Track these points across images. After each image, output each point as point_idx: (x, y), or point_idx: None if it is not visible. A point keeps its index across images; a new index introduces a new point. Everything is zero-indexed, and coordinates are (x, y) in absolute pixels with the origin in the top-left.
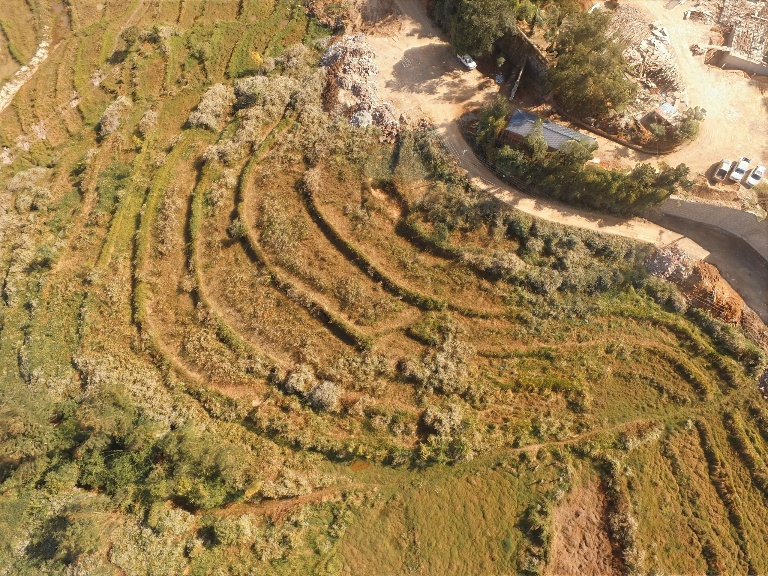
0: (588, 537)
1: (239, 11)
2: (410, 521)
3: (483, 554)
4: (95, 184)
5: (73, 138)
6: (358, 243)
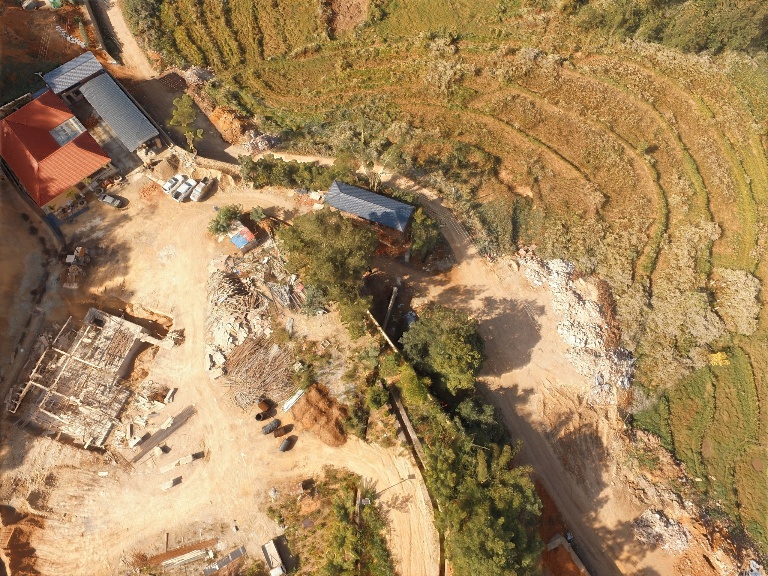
0: (346, 8)
1: None
2: (456, 13)
3: (409, 2)
4: None
5: None
6: (533, 148)
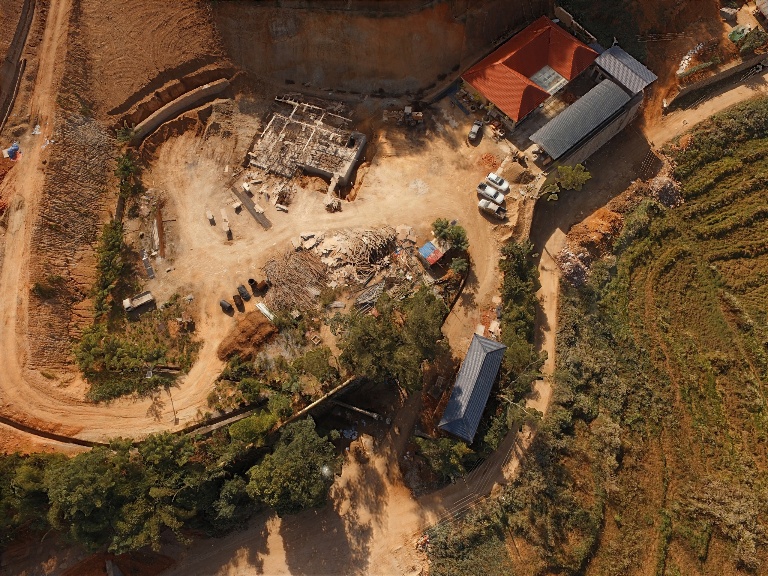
0: None
1: None
2: None
3: None
4: None
5: None
6: None
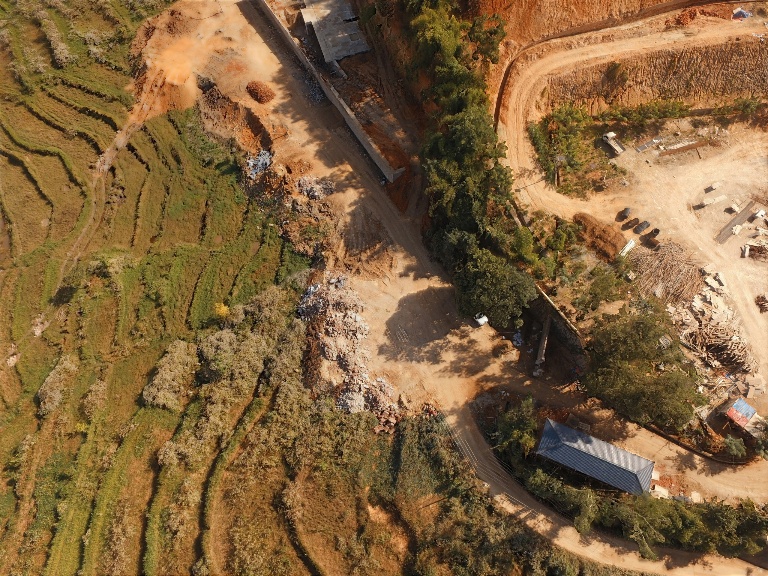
0: None
1: (202, 229)
2: None
3: None
4: (32, 487)
5: (10, 410)
6: None
